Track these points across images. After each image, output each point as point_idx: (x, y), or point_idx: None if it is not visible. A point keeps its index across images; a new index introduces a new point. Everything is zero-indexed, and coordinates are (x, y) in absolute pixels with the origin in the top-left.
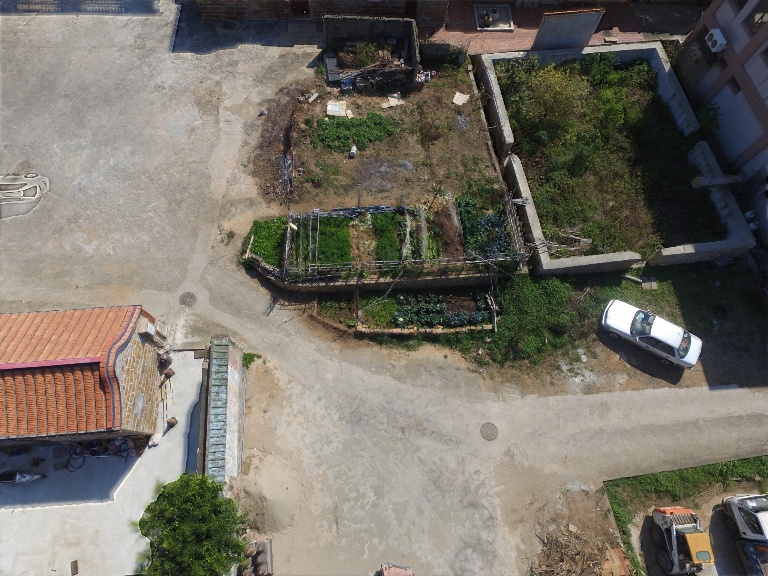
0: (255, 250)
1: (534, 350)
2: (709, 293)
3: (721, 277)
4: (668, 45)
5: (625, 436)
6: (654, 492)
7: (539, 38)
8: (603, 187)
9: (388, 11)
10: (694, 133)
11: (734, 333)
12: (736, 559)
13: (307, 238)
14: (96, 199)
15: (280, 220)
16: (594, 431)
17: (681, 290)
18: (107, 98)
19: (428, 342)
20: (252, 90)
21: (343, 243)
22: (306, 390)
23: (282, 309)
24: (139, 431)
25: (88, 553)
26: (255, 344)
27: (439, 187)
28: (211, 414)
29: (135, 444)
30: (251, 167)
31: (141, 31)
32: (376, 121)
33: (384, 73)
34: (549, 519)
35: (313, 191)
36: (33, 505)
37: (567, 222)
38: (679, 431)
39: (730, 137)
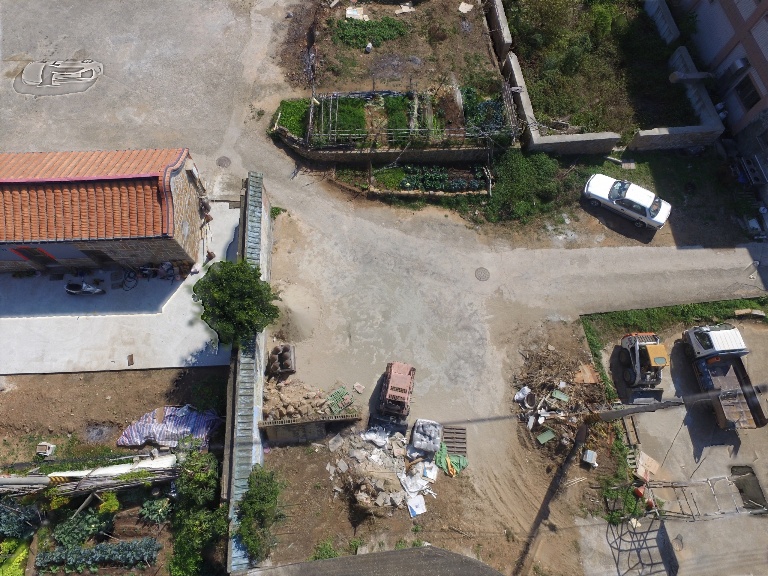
0: (282, 123)
1: (524, 212)
2: (681, 173)
3: (693, 161)
4: None
5: (600, 282)
6: (624, 326)
7: None
8: (591, 86)
9: None
10: (675, 41)
11: (702, 205)
12: (692, 379)
13: (327, 115)
14: (144, 81)
15: (304, 101)
16: (573, 277)
17: (656, 170)
18: (152, 1)
19: (431, 204)
20: None
21: (359, 119)
22: (325, 237)
23: (305, 174)
24: (185, 251)
25: (141, 350)
26: (281, 200)
27: (444, 77)
28: (248, 225)
29: (180, 270)
30: (279, 59)
31: None
32: (390, 23)
33: None
34: (531, 341)
35: (333, 78)
36: (95, 314)
37: (557, 112)
38: (648, 279)
39: (706, 41)
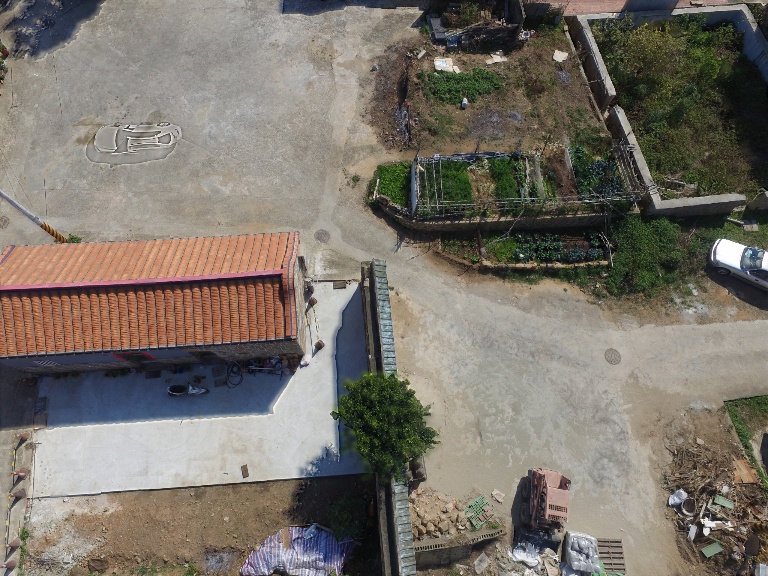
0: (383, 191)
1: (648, 284)
2: None
3: None
4: (753, 7)
5: (740, 361)
6: None
7: None
8: (699, 138)
9: None
10: None
11: None
12: None
13: (430, 181)
14: (227, 146)
15: (402, 165)
16: (711, 357)
17: None
18: (226, 55)
19: (548, 277)
20: (362, 48)
21: (465, 185)
22: (439, 318)
23: (408, 246)
24: (300, 347)
25: (256, 459)
26: (387, 277)
27: (549, 135)
28: (381, 324)
29: (289, 363)
30: (369, 117)
31: None
32: (483, 75)
33: (489, 31)
34: (677, 434)
35: (431, 138)
36: (200, 417)
37: (668, 169)
38: None
39: None
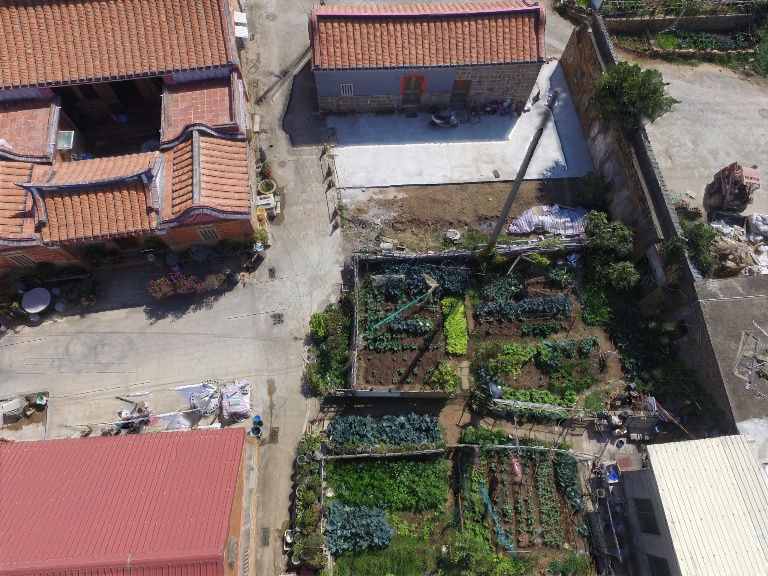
0: None
1: None
2: None
3: None
4: None
5: None
6: None
7: None
8: None
9: None
10: None
11: None
12: None
13: None
14: None
15: None
16: None
17: None
18: None
19: (705, 62)
20: None
21: None
22: None
23: None
24: None
25: (502, 167)
26: None
27: None
28: None
29: (516, 108)
30: None
31: None
32: None
33: None
34: None
35: None
36: (453, 141)
37: None
38: None
39: None
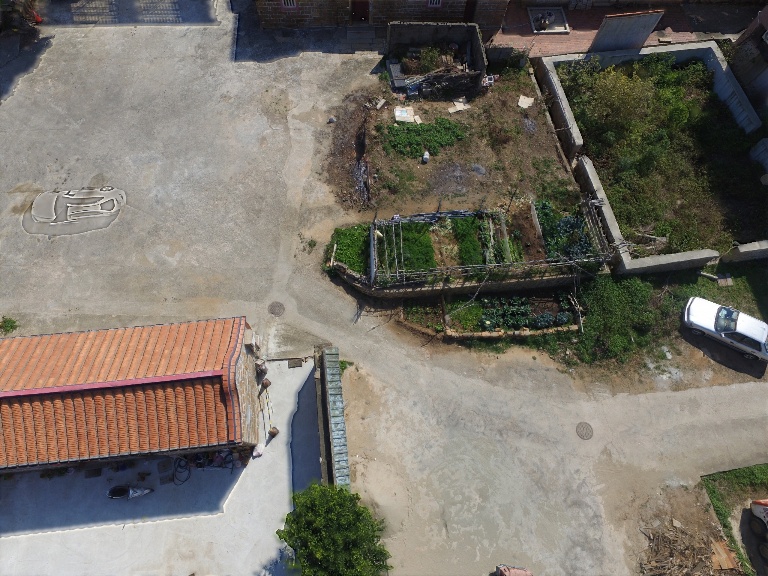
0: (340, 258)
1: (620, 349)
2: None
3: None
4: (723, 44)
5: (717, 431)
6: (750, 485)
7: (598, 40)
8: (670, 186)
9: (447, 16)
10: (755, 130)
11: None
12: None
13: (390, 244)
14: (174, 211)
15: (361, 227)
16: (686, 427)
17: (756, 285)
18: (174, 109)
19: (516, 344)
20: (318, 98)
21: (427, 248)
22: (401, 396)
23: (369, 316)
24: (249, 442)
25: (204, 566)
26: (346, 351)
27: (514, 190)
28: (332, 423)
29: (240, 455)
30: (326, 175)
31: (201, 41)
32: (446, 126)
33: (451, 78)
34: (652, 515)
35: (391, 197)
36: (143, 520)
37: (639, 221)
38: None
39: None
